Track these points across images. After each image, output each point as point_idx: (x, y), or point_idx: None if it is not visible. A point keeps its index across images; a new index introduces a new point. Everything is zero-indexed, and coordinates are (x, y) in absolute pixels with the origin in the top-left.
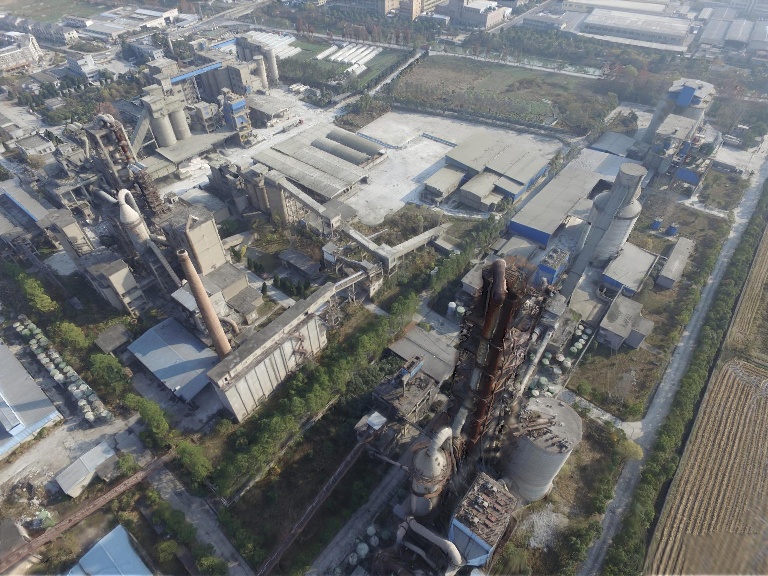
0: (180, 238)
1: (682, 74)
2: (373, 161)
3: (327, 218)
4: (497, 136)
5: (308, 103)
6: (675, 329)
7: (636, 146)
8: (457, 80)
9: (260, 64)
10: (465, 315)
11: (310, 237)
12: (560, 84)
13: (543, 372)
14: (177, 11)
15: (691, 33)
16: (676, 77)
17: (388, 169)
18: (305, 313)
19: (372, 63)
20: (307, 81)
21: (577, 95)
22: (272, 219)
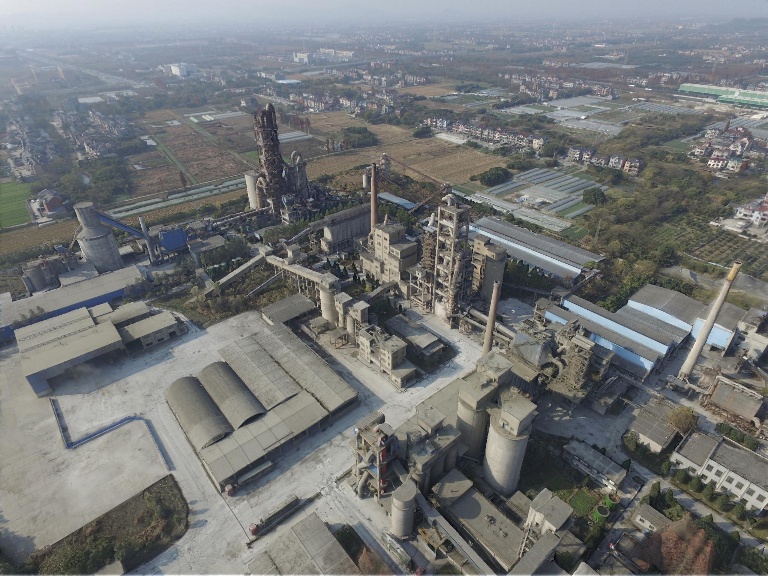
0: None
1: None
2: None
3: None
4: None
5: None
6: (132, 239)
7: None
8: None
9: None
10: None
11: None
12: None
13: None
14: None
15: None
16: None
17: None
18: None
19: None
20: None
21: None
22: None
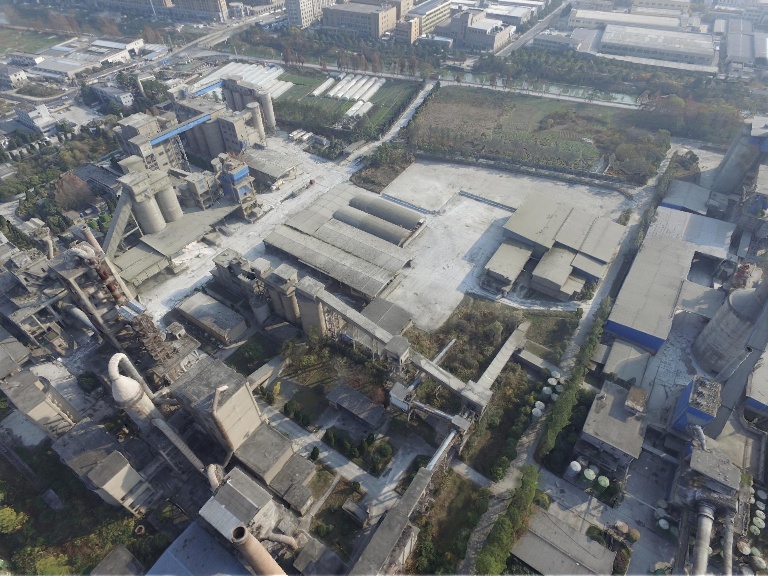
0: (202, 416)
1: (729, 102)
2: (412, 235)
3: (395, 354)
4: (546, 190)
5: (315, 155)
6: None
7: (713, 199)
8: (480, 117)
9: (256, 113)
10: (597, 483)
11: (359, 360)
12: (596, 117)
13: (720, 567)
14: (142, 41)
15: (715, 50)
16: (726, 106)
17: (431, 244)
18: (401, 532)
19: (377, 98)
20: (309, 126)
21: (622, 132)
22: (304, 333)
